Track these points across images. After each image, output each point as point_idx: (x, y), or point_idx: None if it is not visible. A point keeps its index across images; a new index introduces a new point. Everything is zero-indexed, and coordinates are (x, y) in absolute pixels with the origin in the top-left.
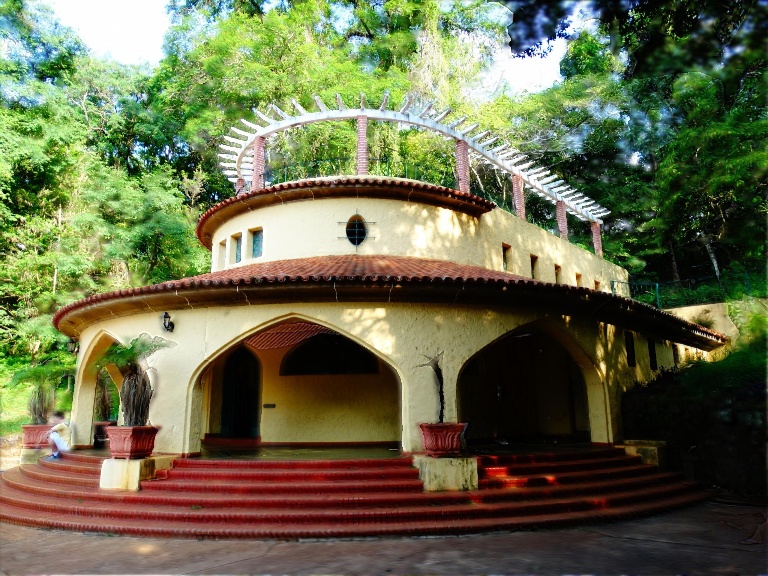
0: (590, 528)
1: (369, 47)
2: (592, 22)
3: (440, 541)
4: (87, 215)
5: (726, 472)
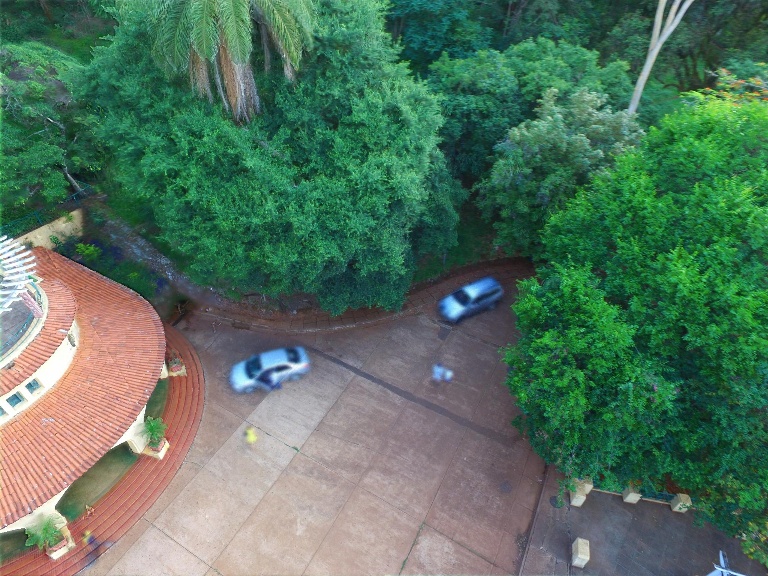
0: (199, 352)
1: None
2: None
3: (208, 376)
4: None
5: None
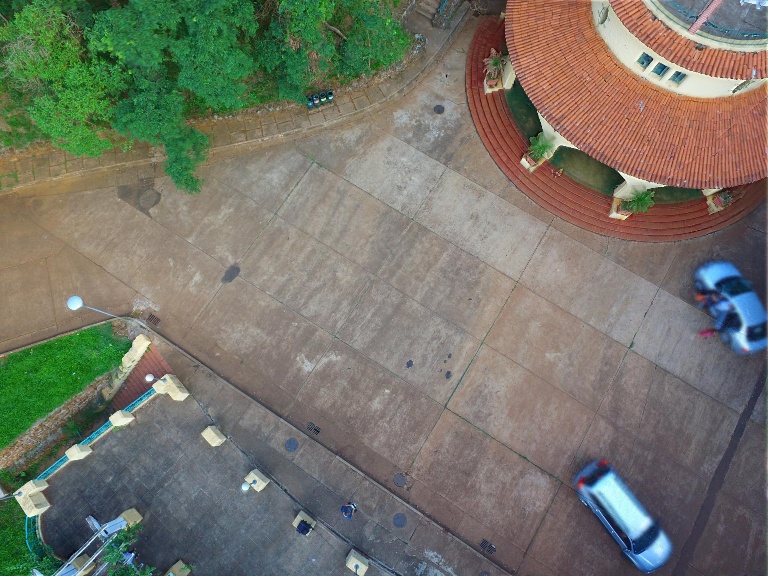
0: (745, 219)
1: None
2: None
3: (711, 237)
4: None
5: None
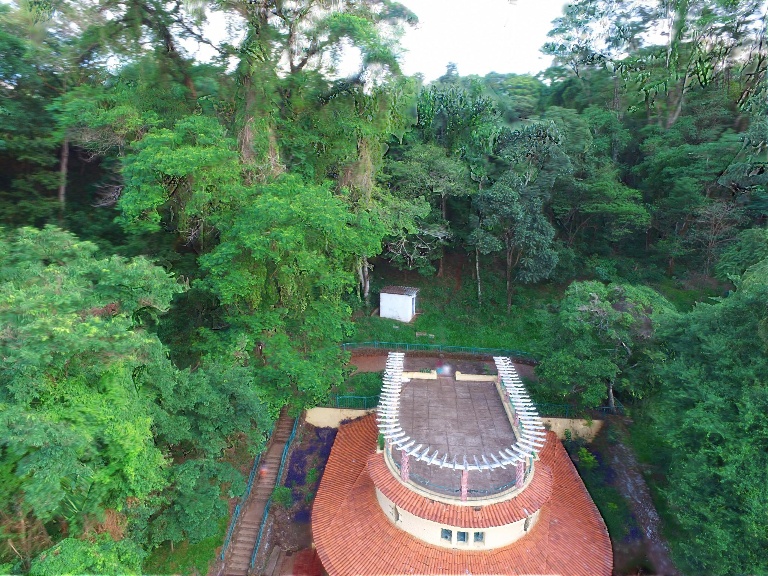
0: None
1: (316, 141)
2: (432, 84)
3: None
4: (171, 420)
5: (615, 567)
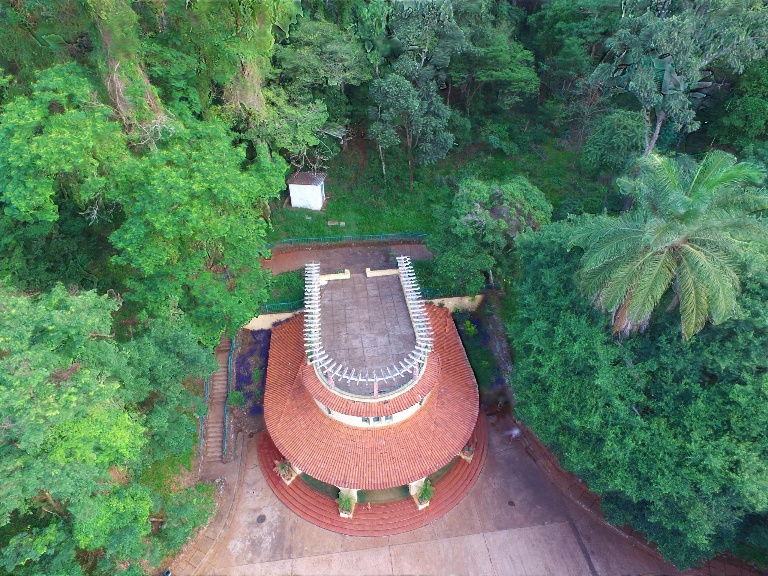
0: (489, 450)
1: (195, 66)
2: None
3: (482, 475)
4: None
5: None
